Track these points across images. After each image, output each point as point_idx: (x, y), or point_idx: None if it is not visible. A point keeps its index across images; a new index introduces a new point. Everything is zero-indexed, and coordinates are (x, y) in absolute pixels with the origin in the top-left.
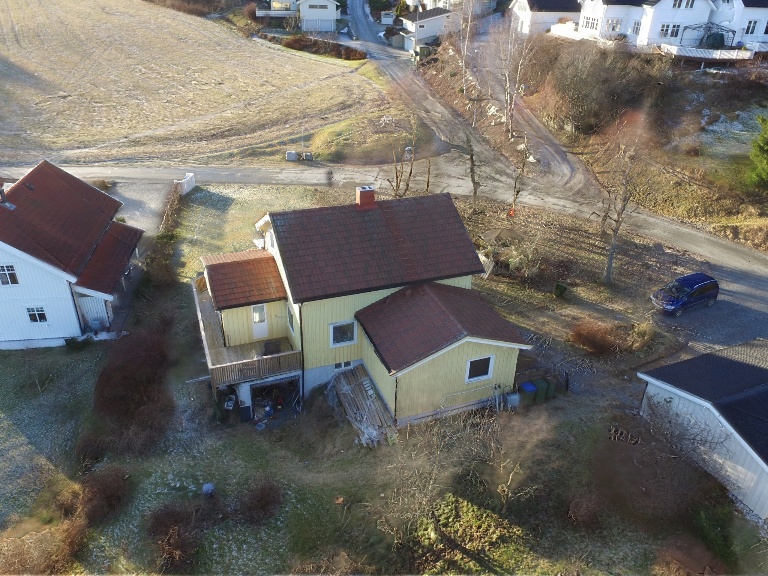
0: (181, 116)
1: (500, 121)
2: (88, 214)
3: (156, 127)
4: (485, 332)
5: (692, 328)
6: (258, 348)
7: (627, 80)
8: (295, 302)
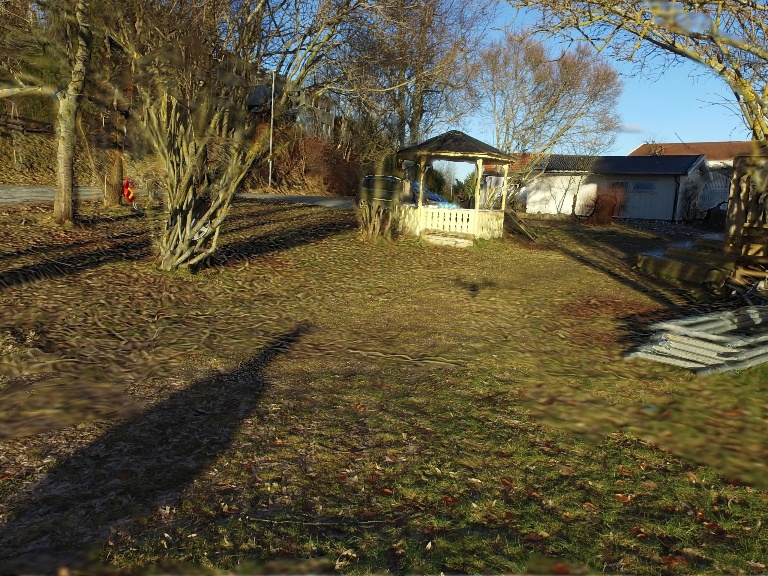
0: None
1: None
2: None
3: None
4: None
5: None
6: None
7: None
8: None
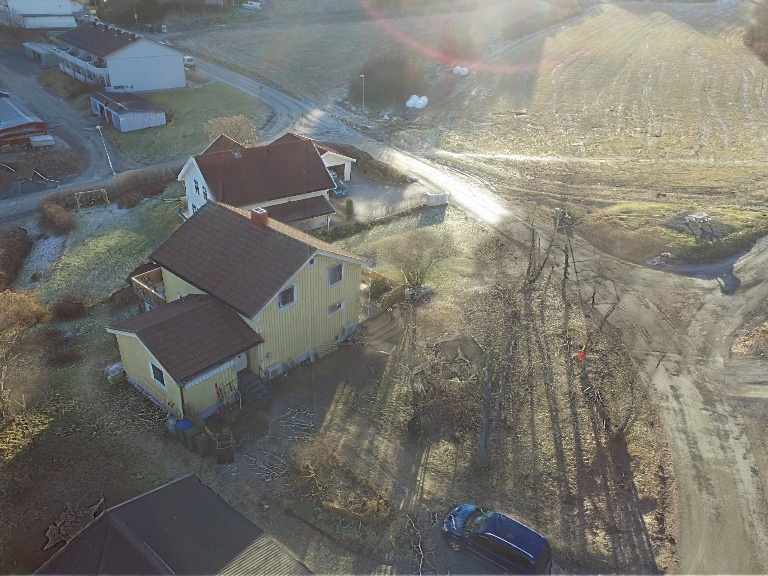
0: (564, 152)
1: None
2: (292, 181)
3: (529, 154)
4: (160, 345)
5: (433, 567)
6: None
7: None
8: None
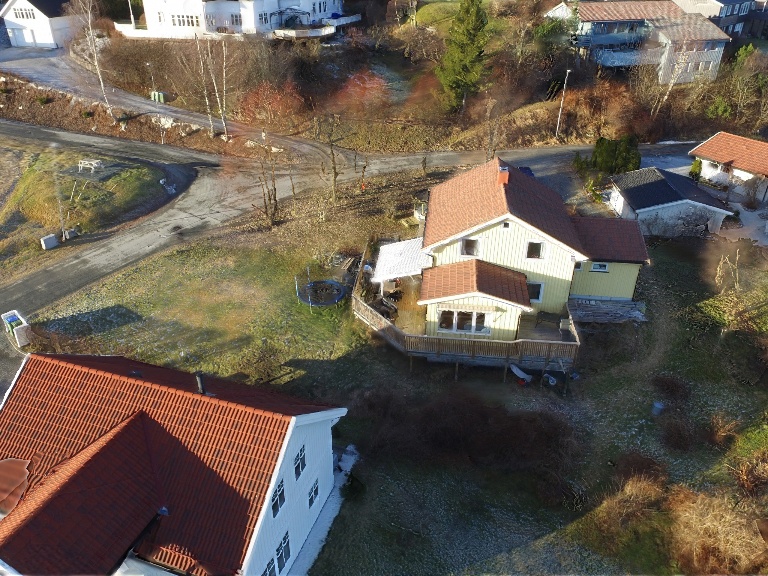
0: None
1: (192, 130)
2: None
3: None
4: None
5: None
6: (527, 331)
7: (284, 64)
8: None
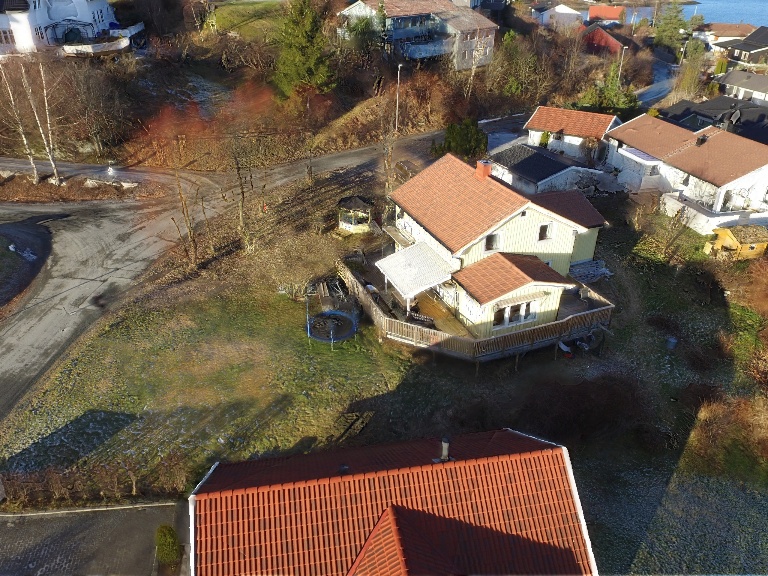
0: None
1: (2, 178)
2: None
3: None
4: None
5: None
6: None
7: None
8: (588, 229)
